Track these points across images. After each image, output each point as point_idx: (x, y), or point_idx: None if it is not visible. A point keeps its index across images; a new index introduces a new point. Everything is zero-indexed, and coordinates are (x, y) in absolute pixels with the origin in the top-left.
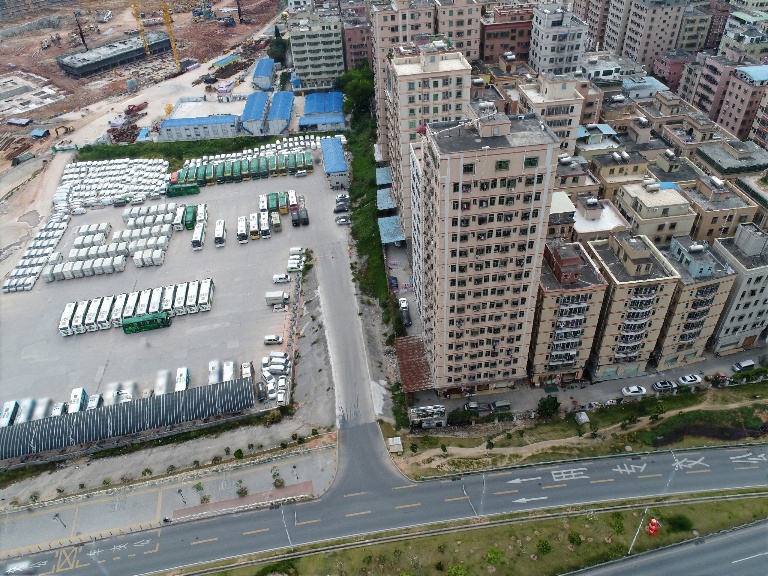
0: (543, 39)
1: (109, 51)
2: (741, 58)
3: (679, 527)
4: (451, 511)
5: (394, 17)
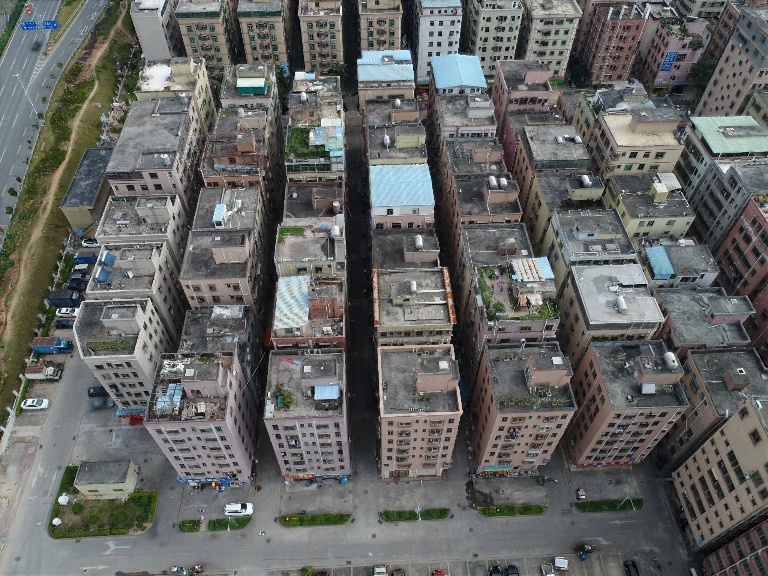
0: None
1: None
2: None
3: None
4: None
5: None
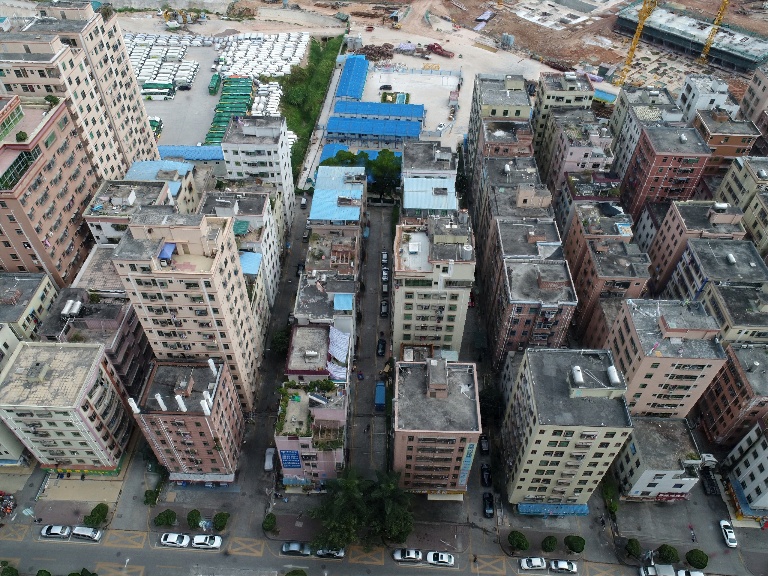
0: None
1: (681, 26)
2: None
3: None
4: None
5: None
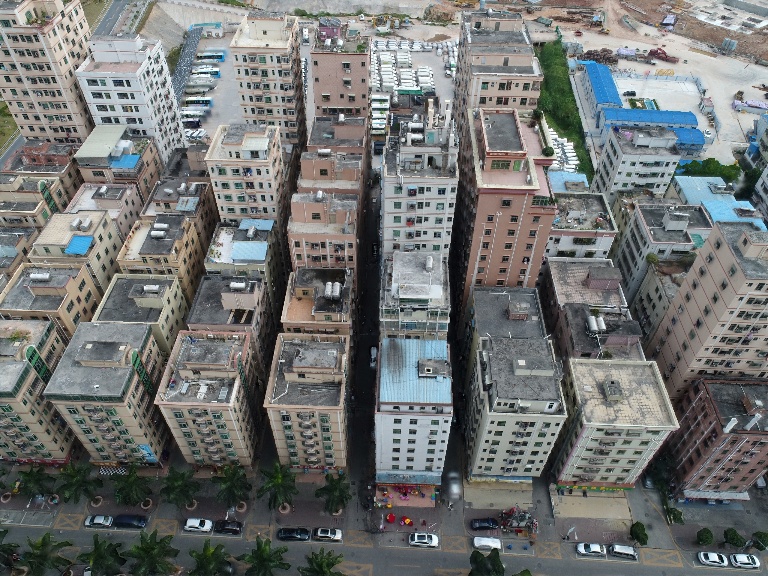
0: None
1: None
2: None
3: None
4: (2, 164)
5: None
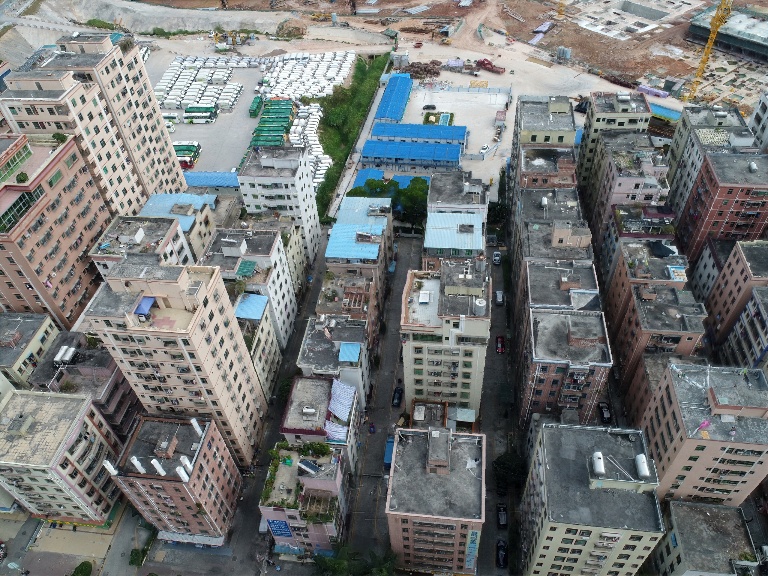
0: None
1: (763, 32)
2: None
3: None
4: None
5: None
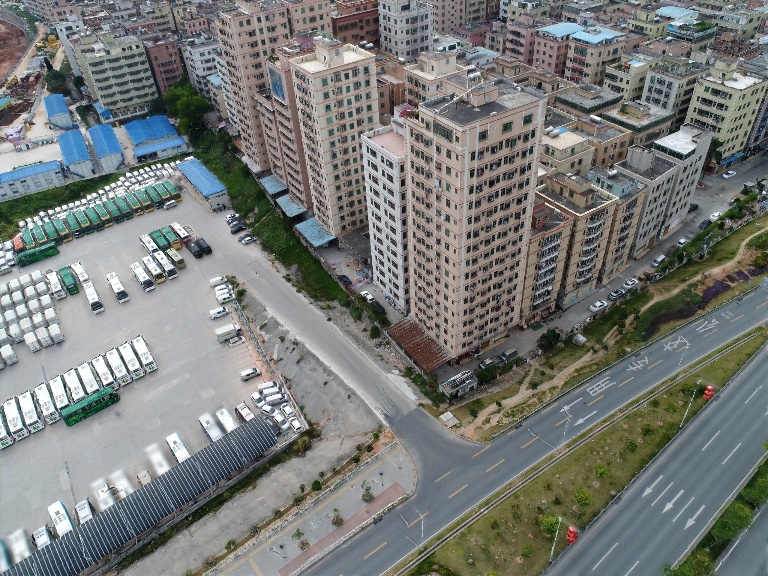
0: (397, 24)
1: None
2: (534, 21)
3: (699, 393)
4: (533, 454)
5: (249, 21)
